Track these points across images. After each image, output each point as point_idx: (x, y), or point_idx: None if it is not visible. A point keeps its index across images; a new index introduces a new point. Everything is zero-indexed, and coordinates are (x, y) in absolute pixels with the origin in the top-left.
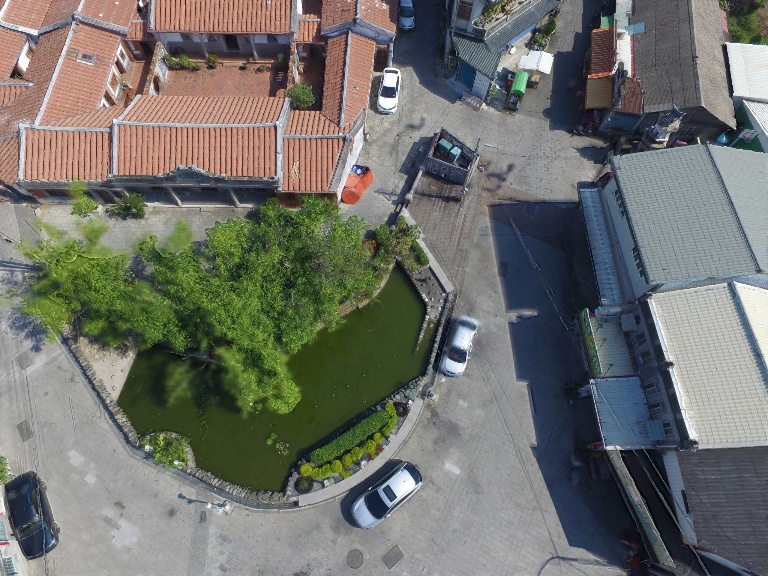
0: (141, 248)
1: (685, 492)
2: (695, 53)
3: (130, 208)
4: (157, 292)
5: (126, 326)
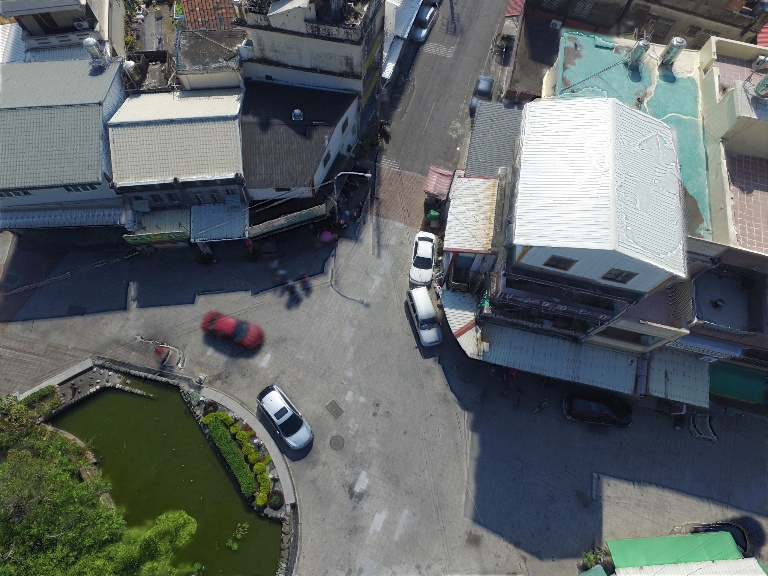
0: None
1: None
2: None
3: None
4: None
5: None
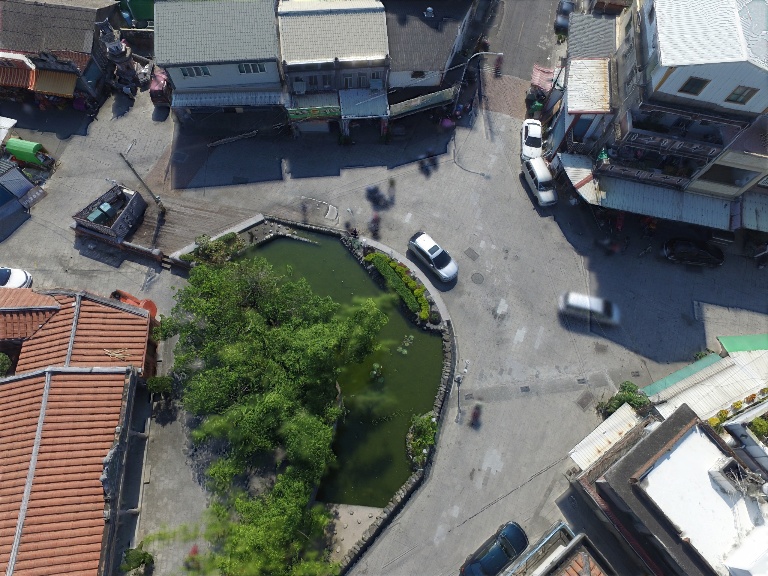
0: (230, 477)
1: (414, 71)
2: (31, 2)
3: (139, 574)
4: (284, 445)
5: (323, 467)
